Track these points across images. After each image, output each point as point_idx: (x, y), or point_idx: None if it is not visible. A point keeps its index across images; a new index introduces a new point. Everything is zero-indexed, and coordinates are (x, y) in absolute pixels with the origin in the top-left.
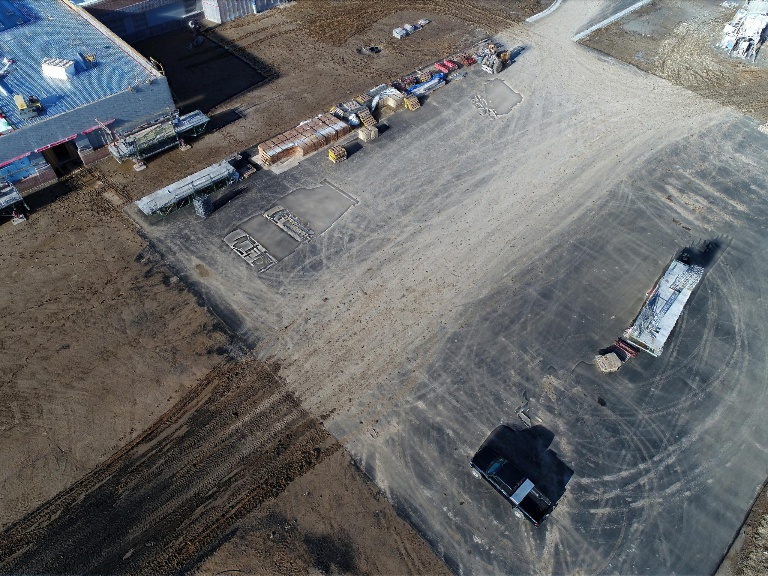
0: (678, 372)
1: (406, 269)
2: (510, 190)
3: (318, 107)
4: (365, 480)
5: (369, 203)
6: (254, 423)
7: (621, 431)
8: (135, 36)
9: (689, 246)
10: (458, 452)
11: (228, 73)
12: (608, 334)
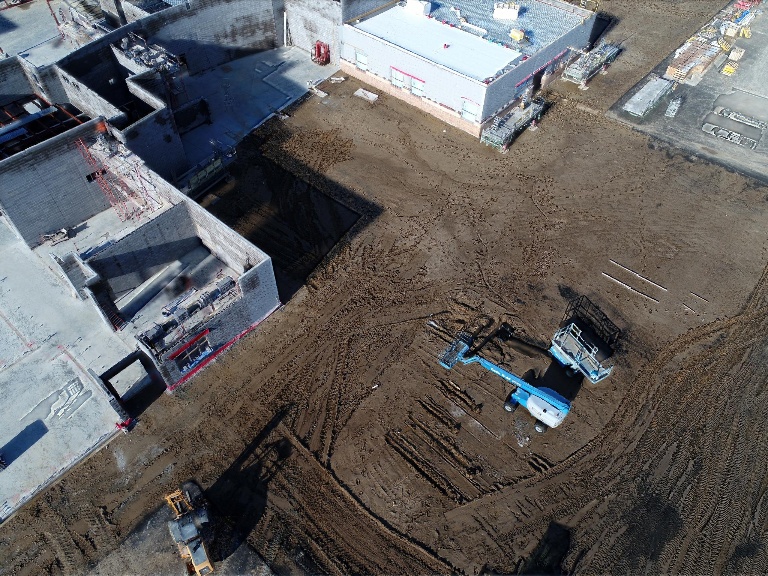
0: None
1: None
2: None
3: (672, 40)
4: None
5: None
6: None
7: None
8: None
9: None
10: None
11: None
12: None
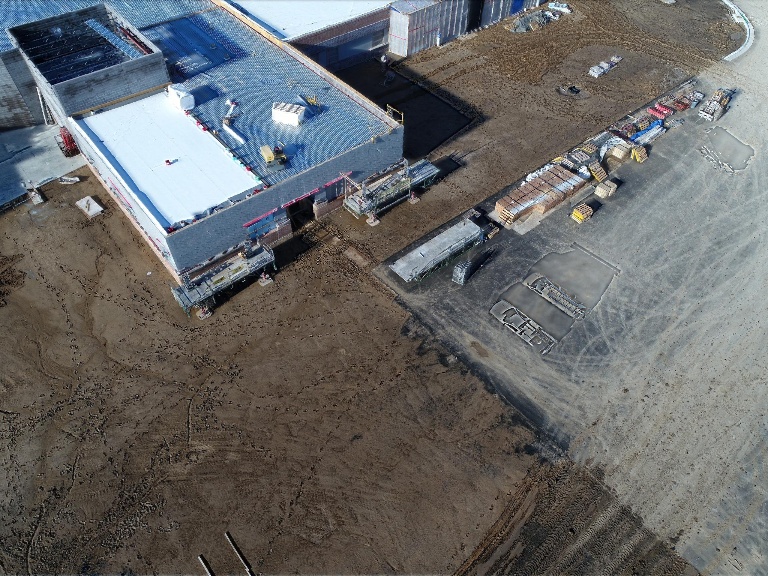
0: None
1: (702, 356)
2: None
3: (537, 156)
4: None
5: (632, 273)
6: (597, 544)
7: None
8: None
9: None
10: None
11: (430, 114)
12: None
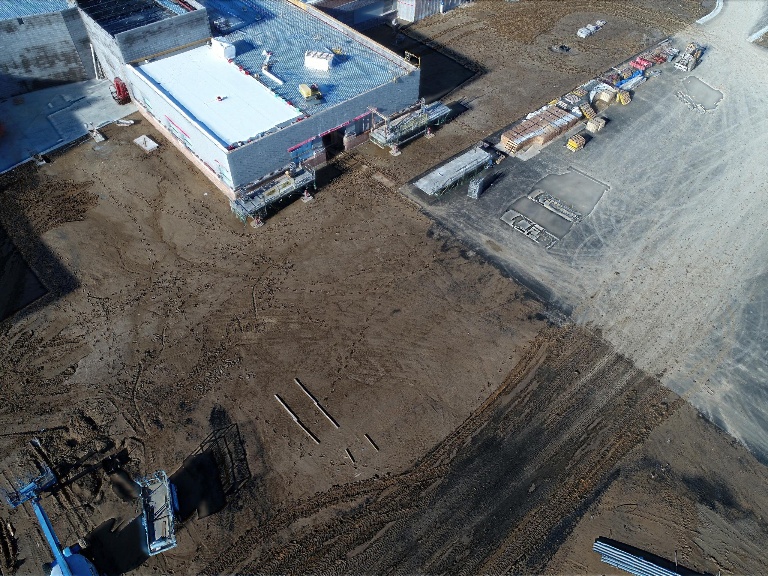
0: None
1: (680, 248)
2: (747, 178)
3: (535, 100)
4: (718, 431)
5: (620, 188)
6: (598, 380)
7: None
8: None
9: None
10: None
11: (439, 68)
12: None
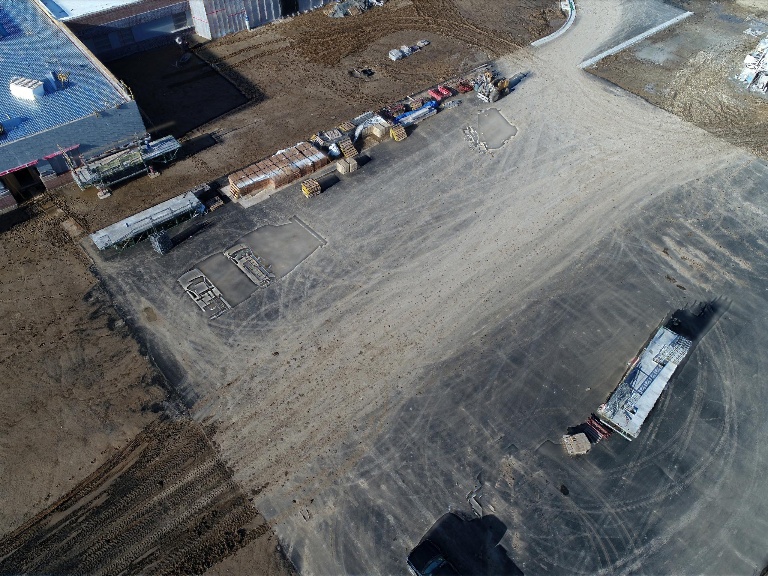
0: (655, 459)
1: (367, 322)
2: (491, 235)
3: (299, 134)
4: (290, 571)
5: (338, 244)
6: (179, 495)
7: (583, 527)
8: (121, 51)
9: (682, 308)
10: (397, 543)
11: (211, 94)
12: (580, 409)
